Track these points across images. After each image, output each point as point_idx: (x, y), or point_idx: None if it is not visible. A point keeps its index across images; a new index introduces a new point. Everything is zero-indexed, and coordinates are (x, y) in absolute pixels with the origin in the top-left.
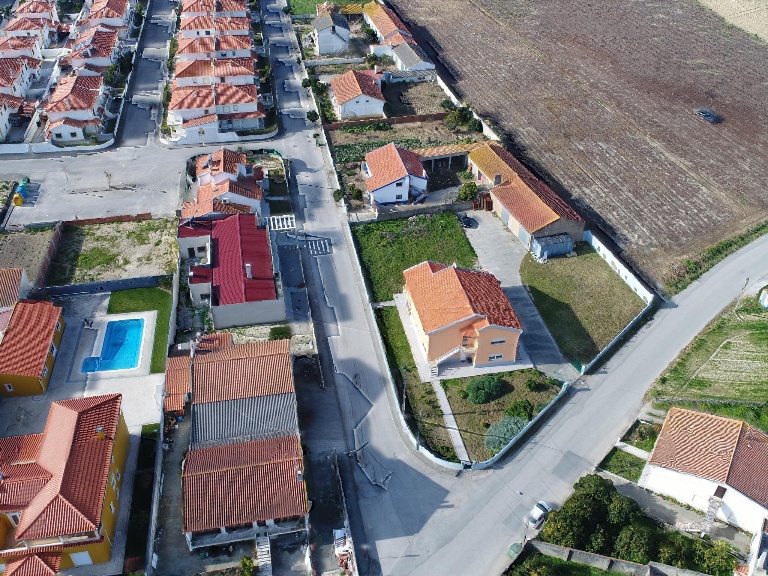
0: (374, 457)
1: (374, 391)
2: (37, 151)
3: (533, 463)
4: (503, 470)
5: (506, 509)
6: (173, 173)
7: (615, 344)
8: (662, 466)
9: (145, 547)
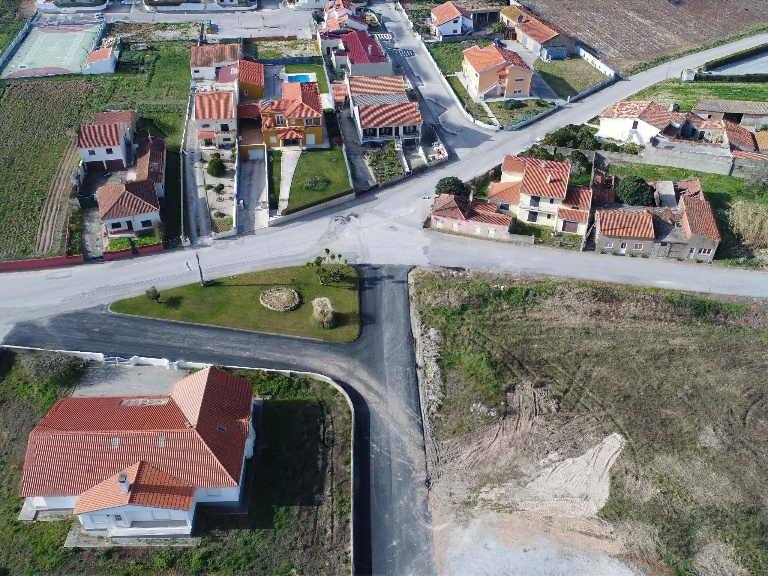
0: (450, 125)
1: (448, 105)
2: (209, 9)
3: (538, 129)
4: (521, 131)
5: (523, 142)
6: (303, 21)
7: (589, 93)
8: (606, 117)
9: (341, 137)
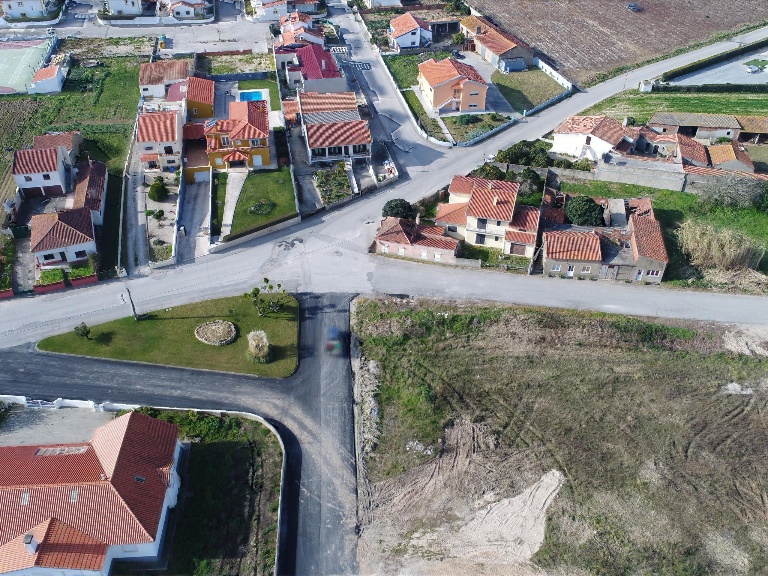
0: (403, 142)
1: (402, 120)
2: (164, 23)
3: (492, 145)
4: (475, 147)
5: (476, 159)
6: (260, 34)
7: (546, 106)
8: (560, 133)
9: (289, 157)
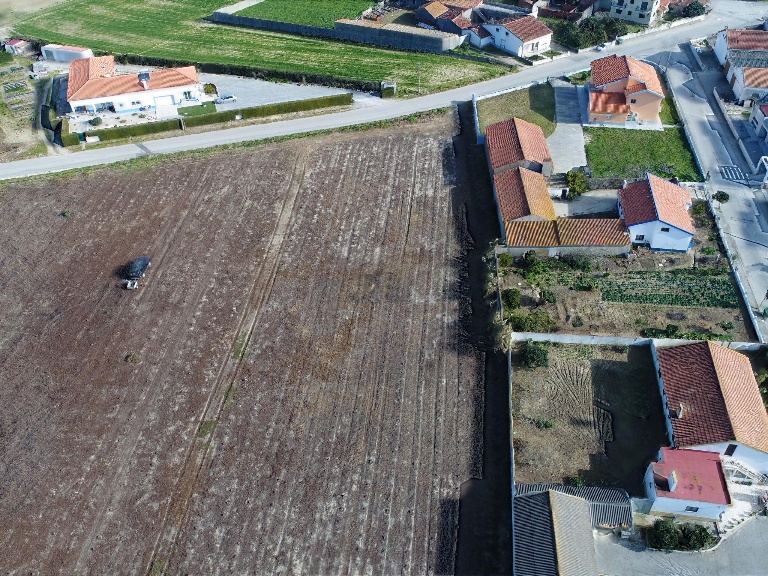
0: None
1: None
2: None
3: None
4: None
5: (618, 52)
6: None
7: None
8: None
9: None
